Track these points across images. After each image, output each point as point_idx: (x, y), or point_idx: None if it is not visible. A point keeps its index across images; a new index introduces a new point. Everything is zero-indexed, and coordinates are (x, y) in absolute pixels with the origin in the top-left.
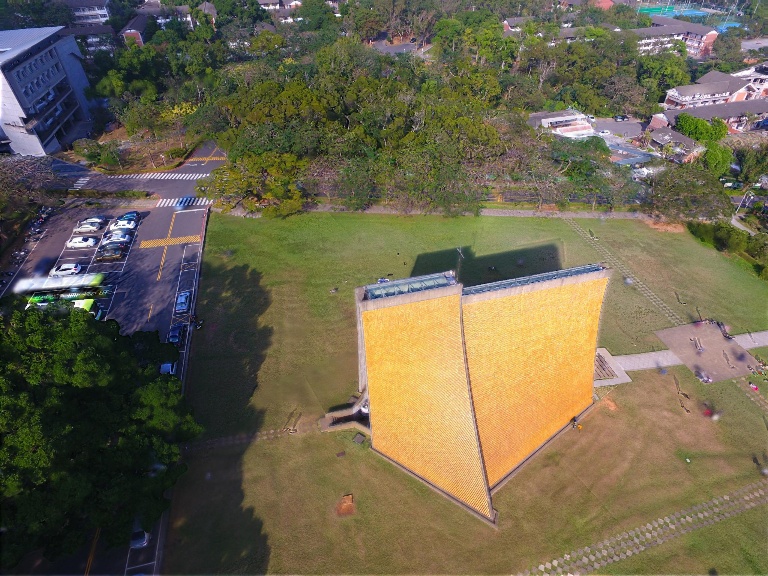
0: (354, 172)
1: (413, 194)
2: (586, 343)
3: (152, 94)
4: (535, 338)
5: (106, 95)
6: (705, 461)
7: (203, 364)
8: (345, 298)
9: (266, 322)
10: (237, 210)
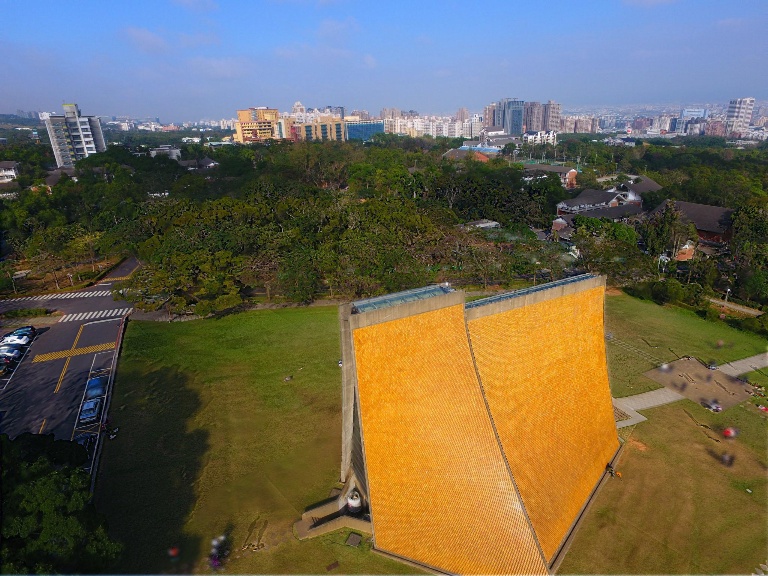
0: (296, 262)
1: (361, 278)
2: (598, 368)
3: (61, 225)
4: (547, 362)
5: (5, 227)
6: (766, 488)
7: (119, 479)
8: (303, 384)
9: (206, 420)
10: (162, 316)
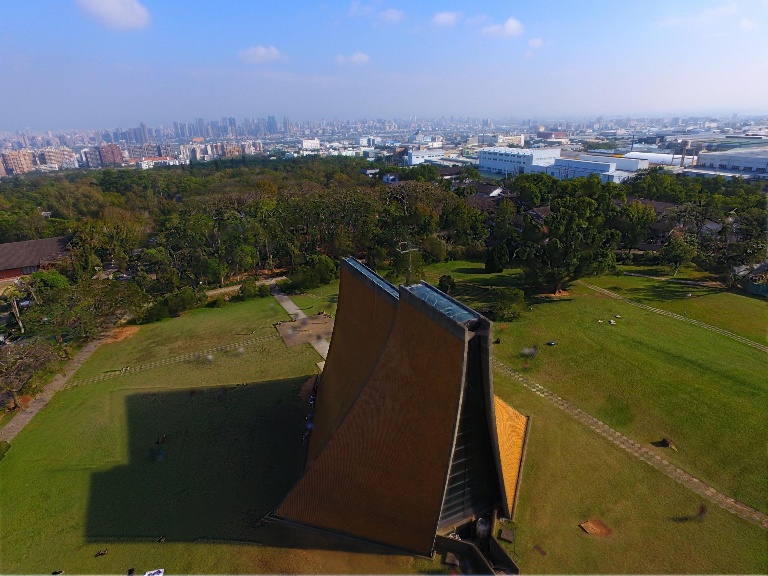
0: None
1: None
2: None
3: None
4: None
5: None
6: None
7: None
8: None
9: None
10: None
